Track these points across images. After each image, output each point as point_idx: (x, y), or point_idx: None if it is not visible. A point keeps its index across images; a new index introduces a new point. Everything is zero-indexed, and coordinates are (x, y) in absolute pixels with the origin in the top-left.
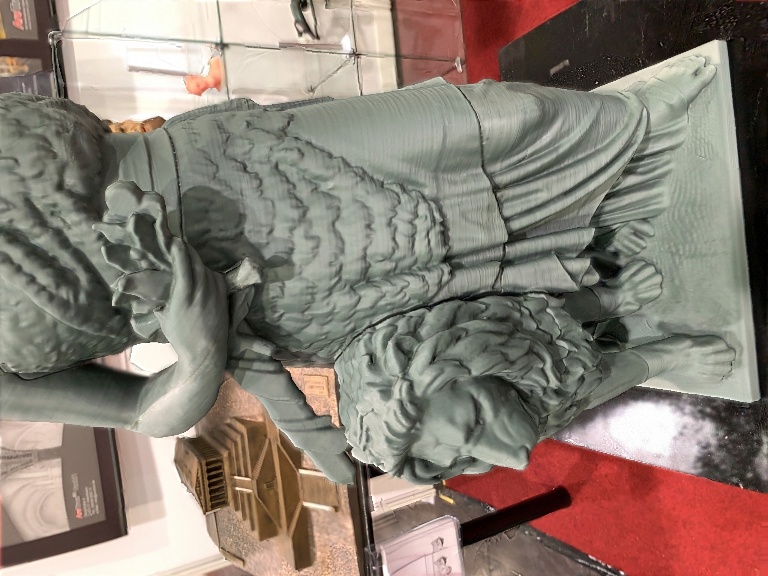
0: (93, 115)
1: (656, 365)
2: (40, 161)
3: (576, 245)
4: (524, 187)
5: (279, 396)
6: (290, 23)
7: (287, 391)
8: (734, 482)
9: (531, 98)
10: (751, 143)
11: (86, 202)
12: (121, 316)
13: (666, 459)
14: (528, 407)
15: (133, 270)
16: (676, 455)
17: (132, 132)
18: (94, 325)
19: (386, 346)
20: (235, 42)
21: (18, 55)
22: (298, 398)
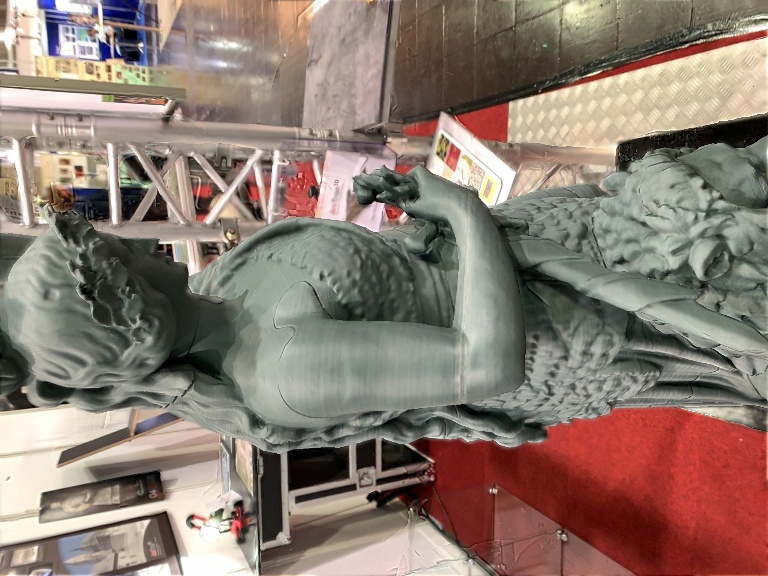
0: None
1: None
2: None
3: None
4: None
5: None
6: None
7: (572, 253)
8: None
9: None
10: None
11: None
12: None
13: None
14: None
15: None
16: None
17: None
18: None
19: None
20: None
21: None
22: None
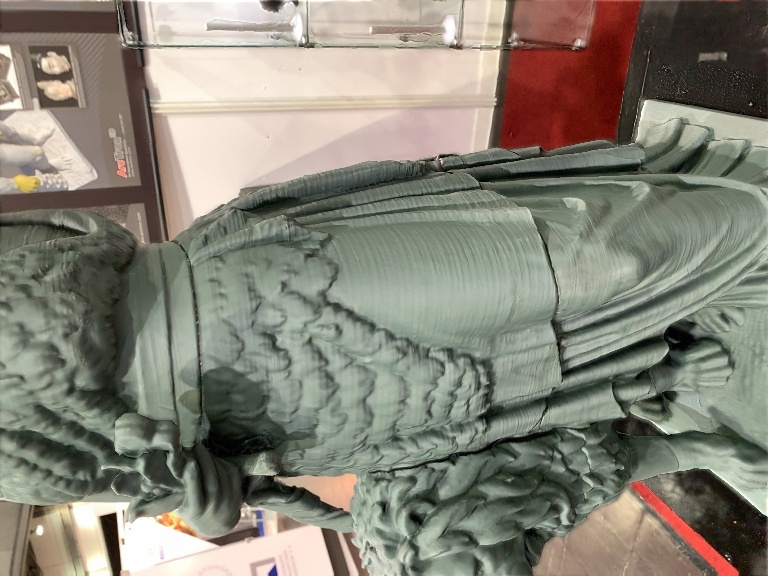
0: (110, 256)
1: (688, 465)
2: (47, 373)
3: (641, 367)
4: (596, 331)
5: (293, 510)
6: None
7: (301, 507)
8: (726, 556)
9: (633, 263)
10: None
11: (100, 394)
12: None
13: (672, 501)
14: (532, 548)
15: (144, 495)
16: (682, 504)
17: (154, 273)
18: None
19: (401, 499)
20: None
21: None
22: None
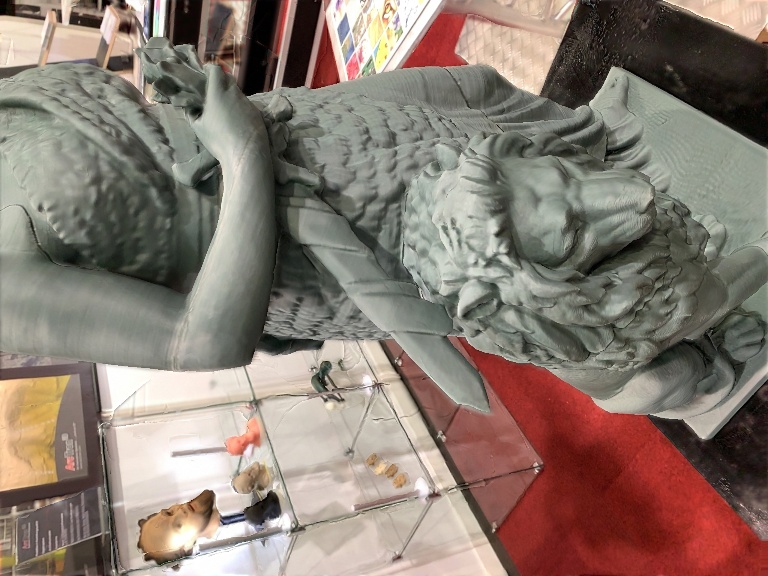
0: None
1: (767, 246)
2: None
3: None
4: (515, 123)
5: (345, 244)
6: (316, 410)
7: (352, 240)
8: None
9: None
10: (691, 91)
11: None
12: (162, 174)
13: None
14: None
15: None
16: None
17: None
18: (135, 160)
19: (438, 169)
20: (267, 396)
21: (68, 492)
22: (367, 248)
